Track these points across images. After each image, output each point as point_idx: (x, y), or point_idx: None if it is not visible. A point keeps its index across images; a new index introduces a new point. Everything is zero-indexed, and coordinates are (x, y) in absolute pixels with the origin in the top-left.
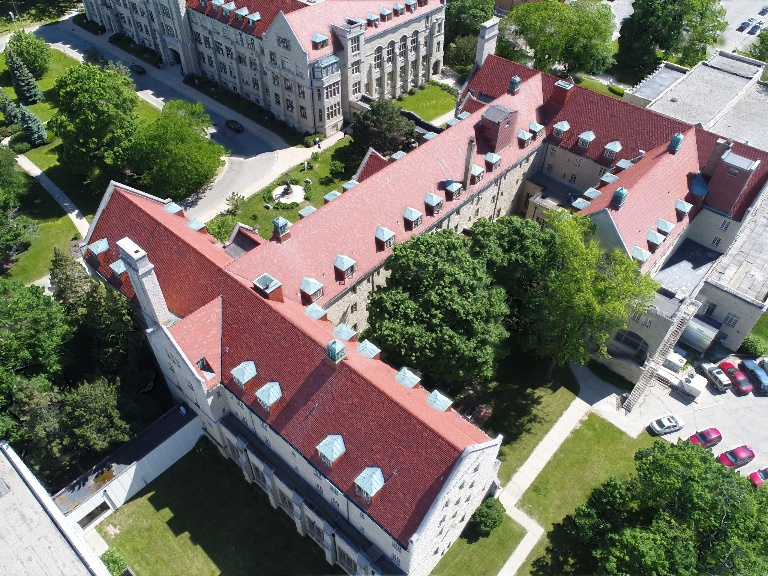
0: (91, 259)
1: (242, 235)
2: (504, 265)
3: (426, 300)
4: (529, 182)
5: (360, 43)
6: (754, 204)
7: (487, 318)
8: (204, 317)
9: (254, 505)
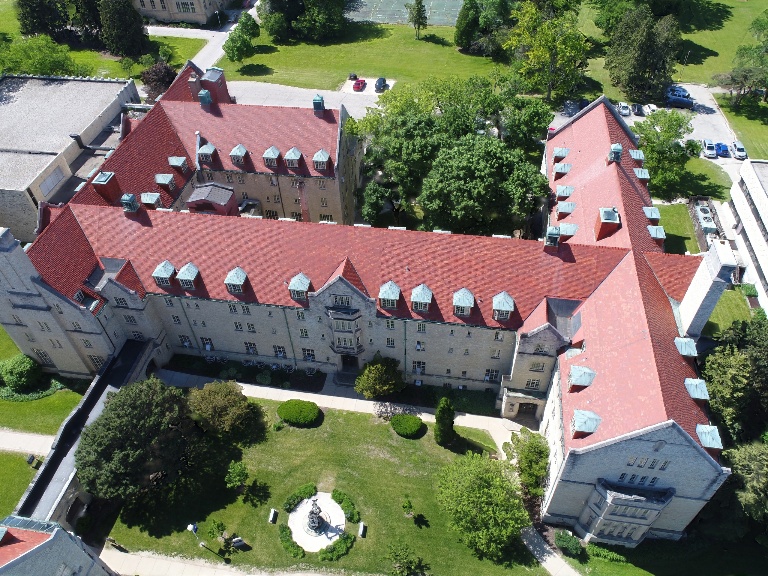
0: (717, 459)
1: None
2: None
3: None
4: None
5: None
6: None
7: None
8: None
9: None
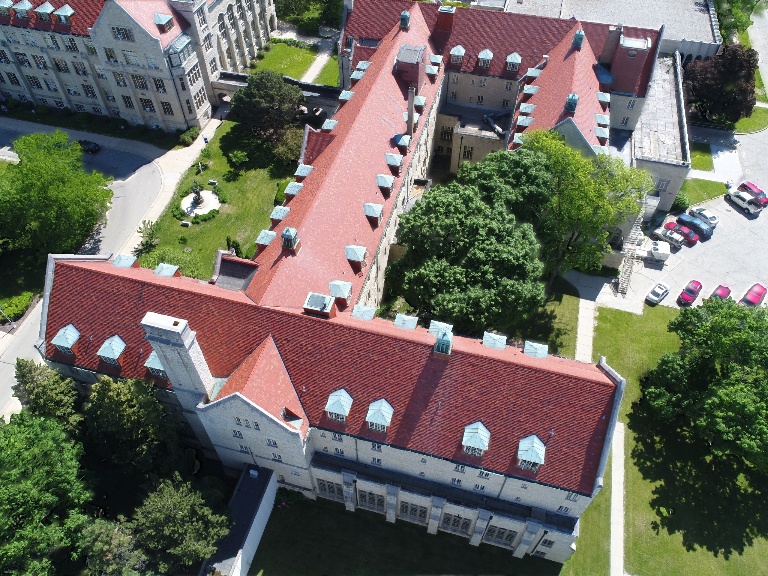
0: (58, 356)
1: (228, 263)
2: (520, 200)
3: (468, 260)
4: (442, 115)
5: (205, 14)
6: None
7: (531, 256)
8: (266, 365)
9: (371, 530)
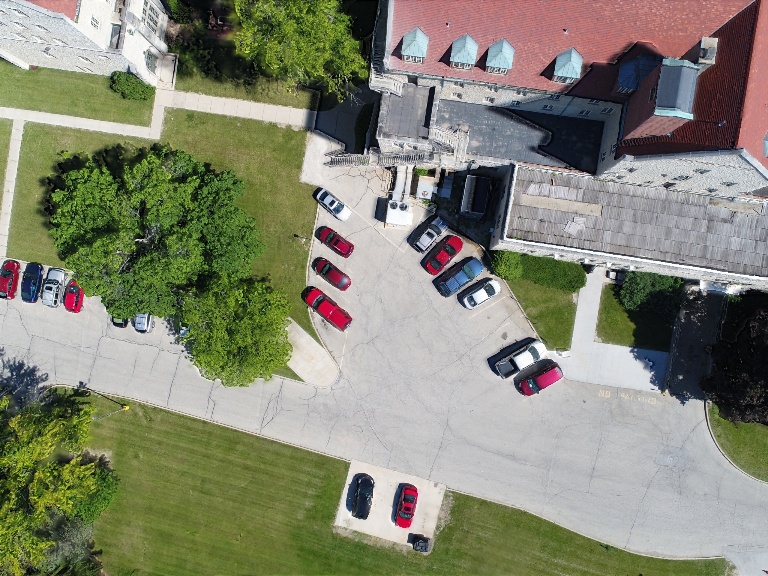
0: None
1: None
2: None
3: None
4: None
5: None
6: (640, 158)
7: None
8: None
9: None
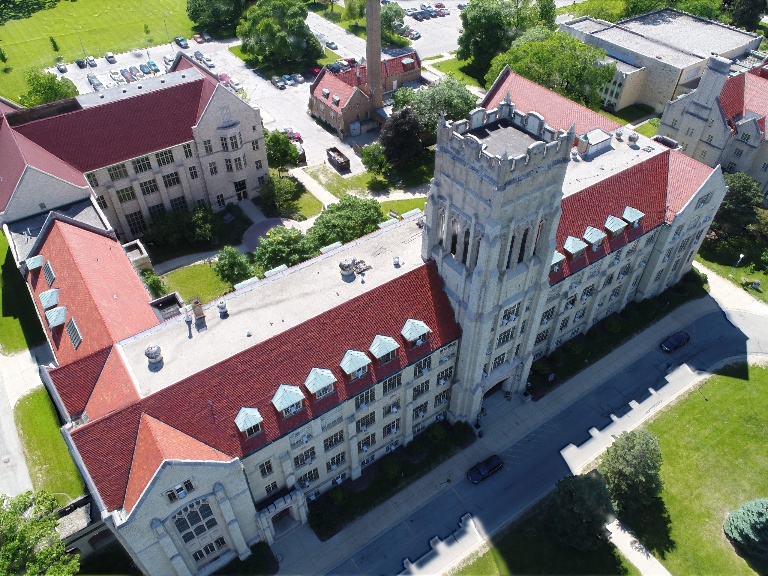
0: None
1: None
2: None
3: None
4: None
5: None
6: None
7: None
8: None
9: None
